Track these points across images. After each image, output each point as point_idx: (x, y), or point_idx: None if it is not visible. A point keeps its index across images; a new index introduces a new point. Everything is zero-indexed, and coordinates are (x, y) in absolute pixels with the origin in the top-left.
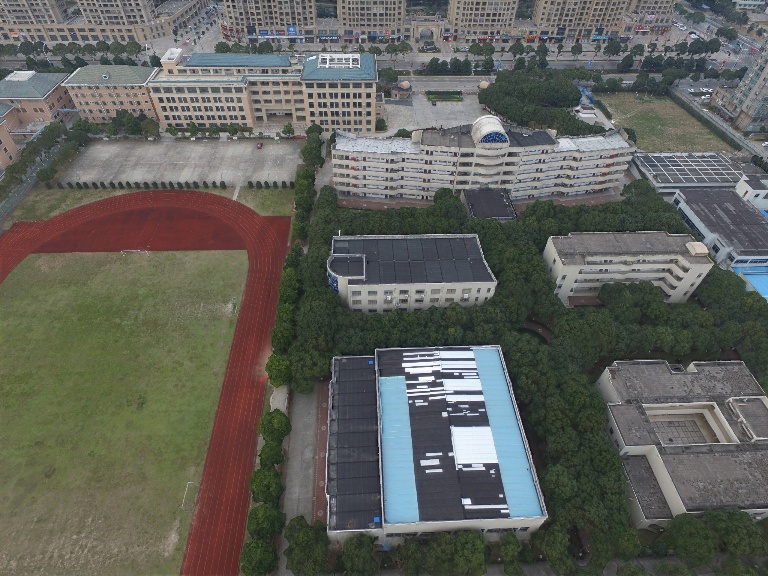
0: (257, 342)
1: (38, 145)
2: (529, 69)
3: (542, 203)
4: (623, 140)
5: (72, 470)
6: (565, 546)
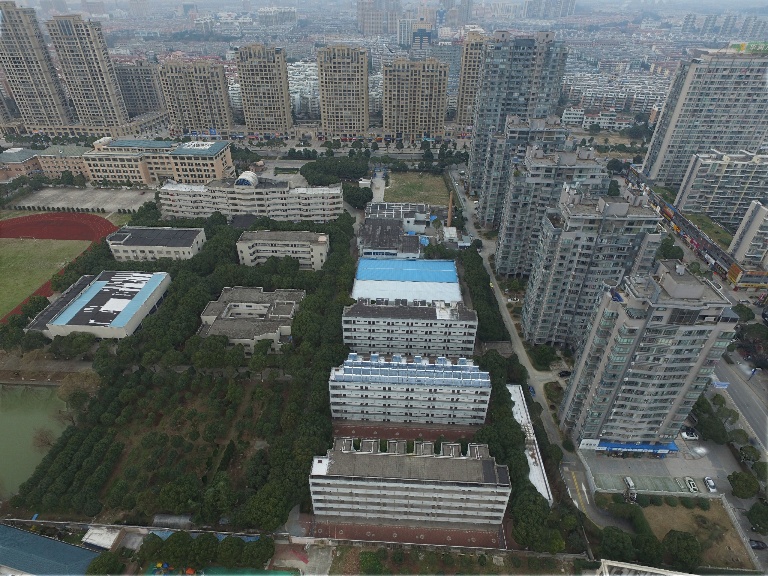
0: None
1: (6, 186)
2: None
3: (261, 218)
4: (339, 189)
5: None
6: (129, 342)
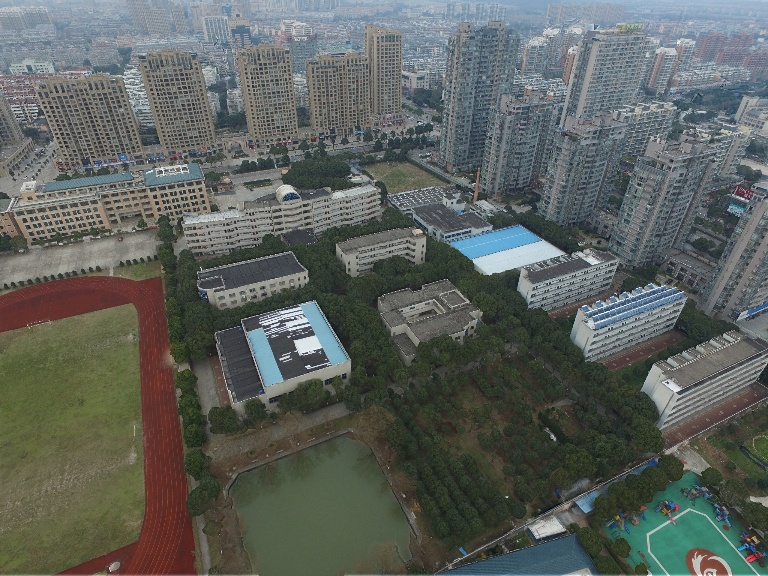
0: (158, 349)
1: None
2: (315, 158)
3: (330, 229)
4: (373, 187)
5: (42, 449)
6: (363, 372)
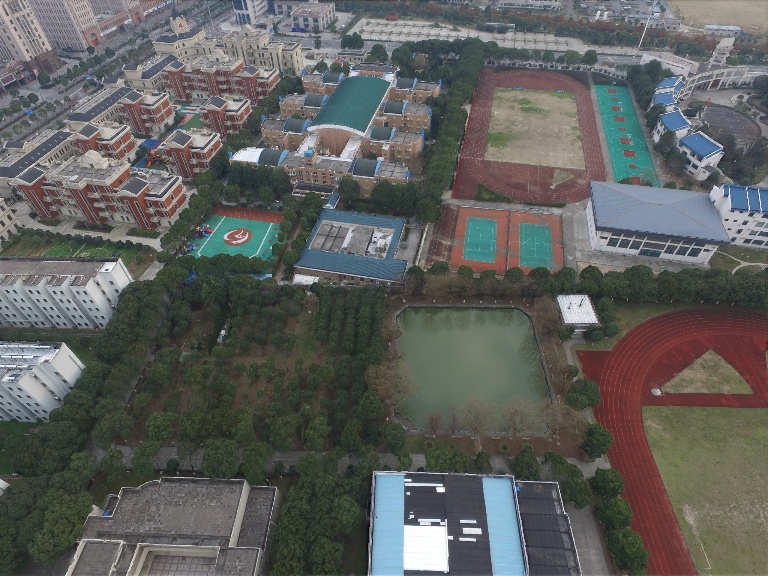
0: None
1: None
2: None
3: None
4: None
5: None
6: None
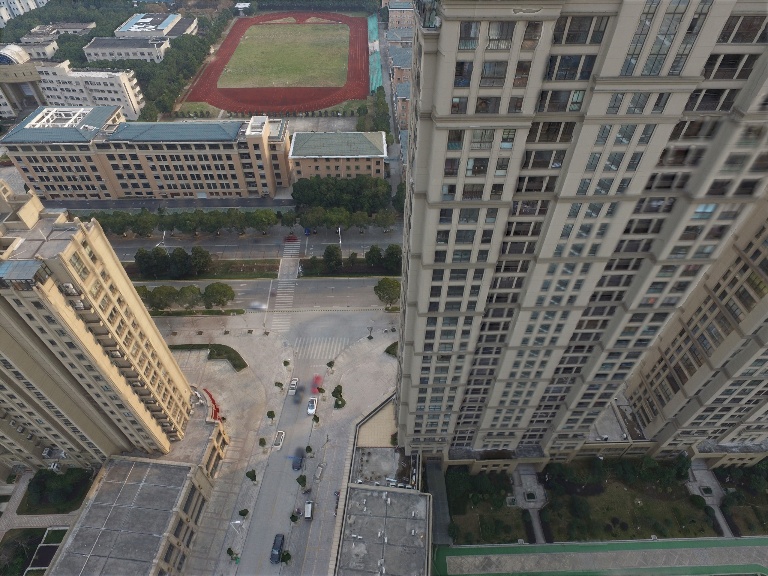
0: None
1: None
2: None
3: None
4: None
5: None
6: None
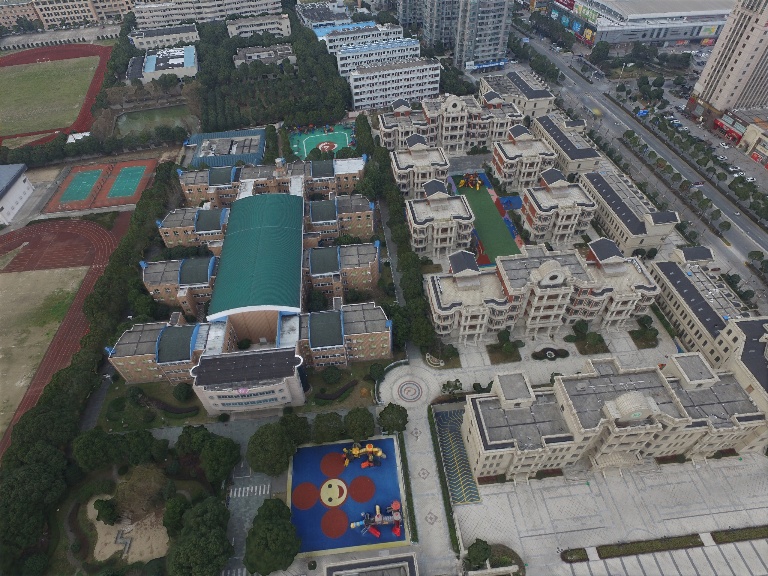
0: None
1: None
2: None
3: None
4: None
5: (35, 101)
6: (202, 74)
